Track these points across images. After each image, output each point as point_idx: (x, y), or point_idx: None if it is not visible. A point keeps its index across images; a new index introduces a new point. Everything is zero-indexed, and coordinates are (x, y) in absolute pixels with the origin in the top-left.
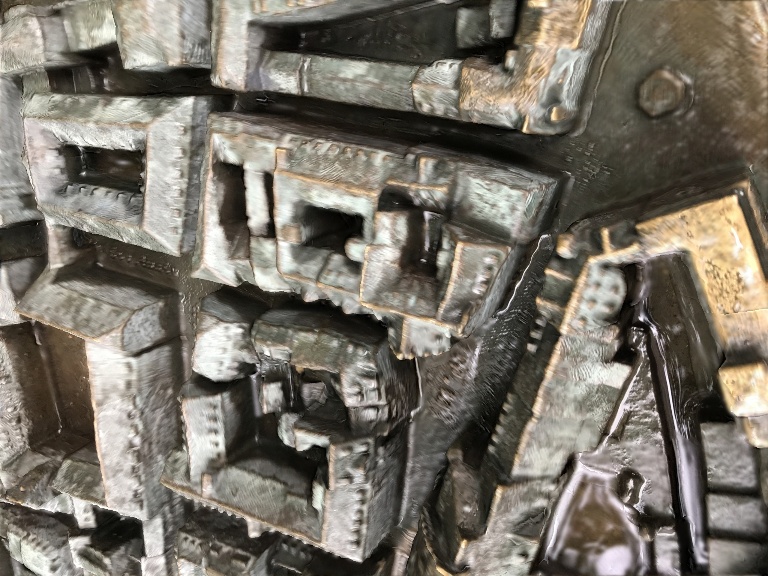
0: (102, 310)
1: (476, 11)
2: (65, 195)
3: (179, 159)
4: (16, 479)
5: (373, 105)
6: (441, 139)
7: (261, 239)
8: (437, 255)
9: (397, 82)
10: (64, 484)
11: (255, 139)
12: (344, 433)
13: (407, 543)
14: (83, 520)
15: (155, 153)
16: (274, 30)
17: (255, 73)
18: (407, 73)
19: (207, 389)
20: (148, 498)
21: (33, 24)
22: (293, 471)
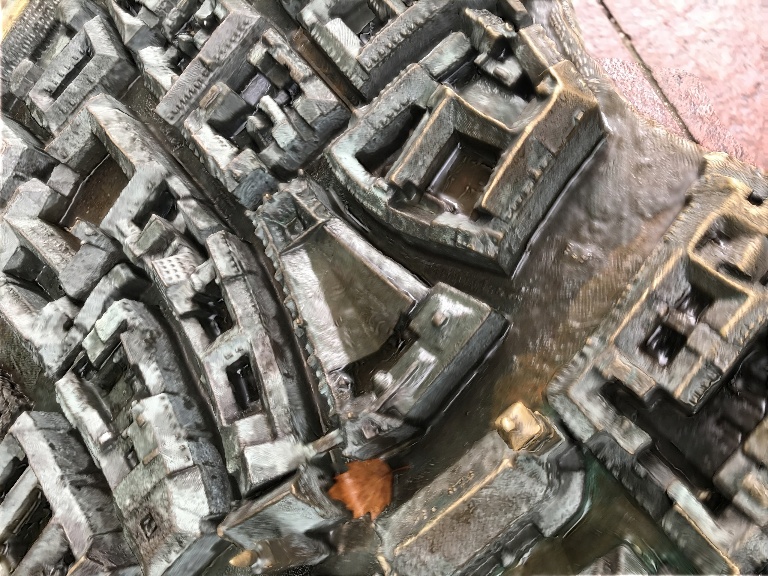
0: None
1: None
2: None
3: (102, 30)
4: None
5: None
6: None
7: None
8: None
9: None
10: None
11: None
12: None
13: (296, 39)
14: (130, 232)
15: None
16: None
17: None
18: None
19: None
20: None
21: None
22: None
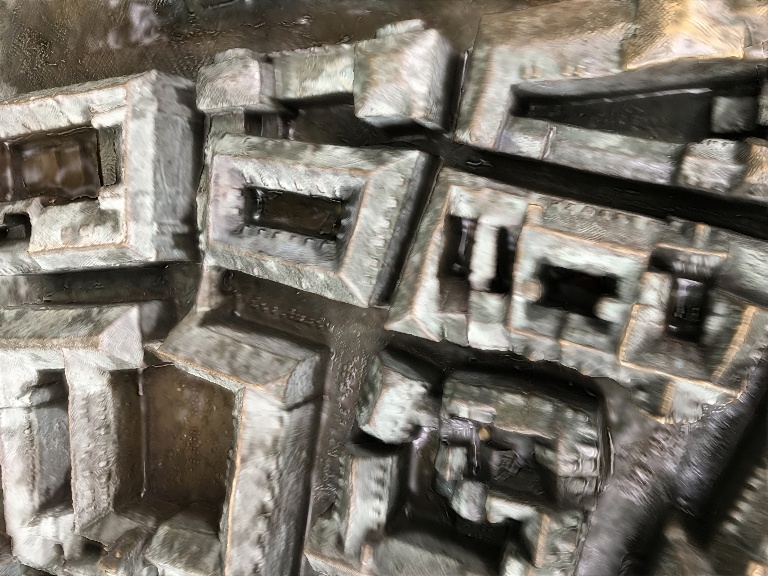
0: (262, 358)
1: (736, 101)
2: (241, 235)
3: (391, 209)
4: (79, 548)
5: (619, 175)
6: (679, 214)
7: (485, 294)
8: (708, 320)
9: (654, 156)
10: (162, 553)
11: (501, 194)
12: (550, 505)
13: None
14: None
15: (371, 200)
16: (516, 98)
17: (500, 134)
18: (664, 149)
19: (374, 451)
20: (266, 574)
21: (254, 66)
22: (461, 548)
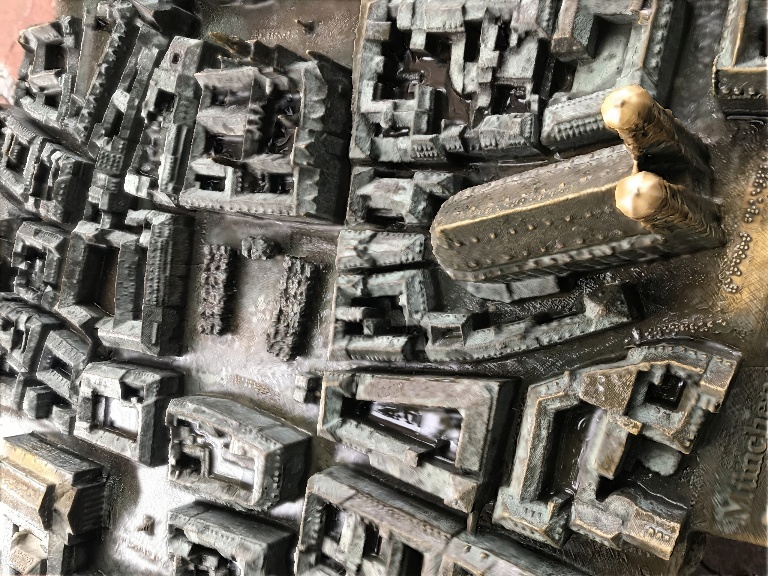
0: None
1: (6, 370)
2: None
3: None
4: None
5: None
6: None
7: None
8: None
9: (8, 360)
10: None
11: None
12: None
13: None
14: None
15: None
16: None
17: None
18: None
19: None
20: None
21: None
22: None
